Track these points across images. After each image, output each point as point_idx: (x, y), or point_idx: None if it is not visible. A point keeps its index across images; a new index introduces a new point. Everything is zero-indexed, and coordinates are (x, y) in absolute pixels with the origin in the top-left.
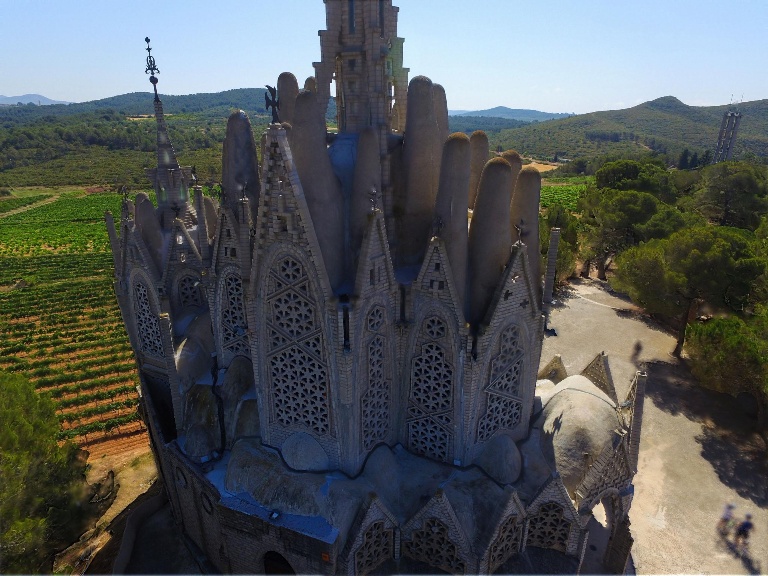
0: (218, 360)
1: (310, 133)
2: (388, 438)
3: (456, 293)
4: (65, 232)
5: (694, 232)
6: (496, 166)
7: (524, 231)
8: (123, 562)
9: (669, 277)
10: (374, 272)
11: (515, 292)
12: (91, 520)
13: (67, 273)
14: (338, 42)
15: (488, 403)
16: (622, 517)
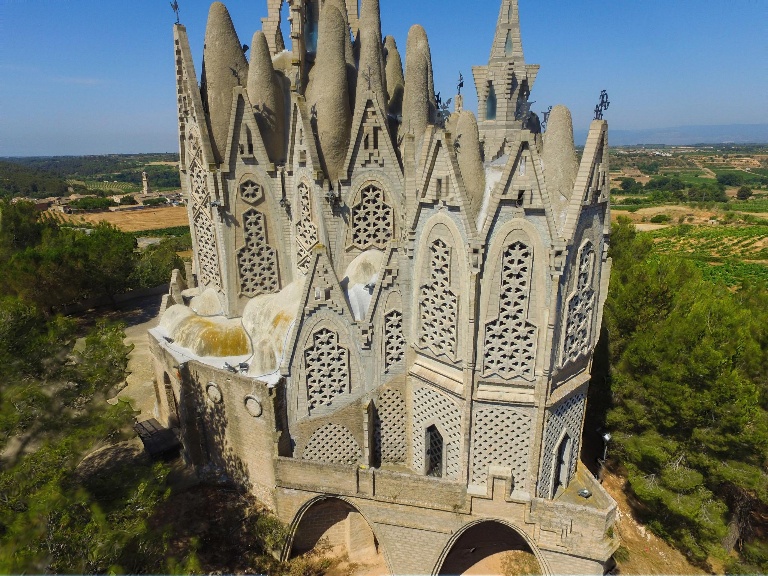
0: None
1: None
2: None
3: None
4: None
5: None
6: None
7: None
8: None
9: None
10: None
11: None
12: None
13: None
14: None
15: None
16: None
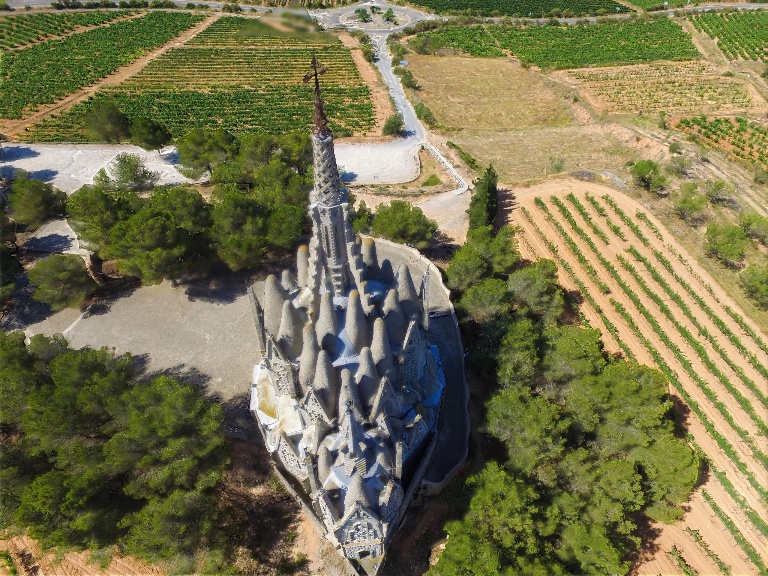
0: None
1: None
2: None
3: None
4: None
5: (151, 225)
6: None
7: None
8: None
9: (180, 253)
10: None
11: None
12: None
13: None
14: None
15: None
16: None
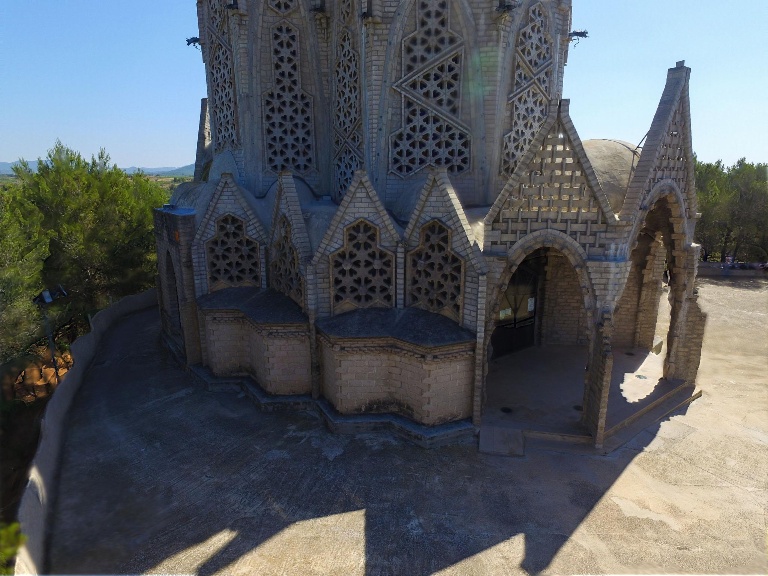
0: None
1: None
2: (313, 180)
3: None
4: None
5: None
6: None
7: None
8: (137, 304)
9: None
10: None
11: None
12: (146, 283)
13: None
14: None
15: (403, 111)
16: (597, 313)
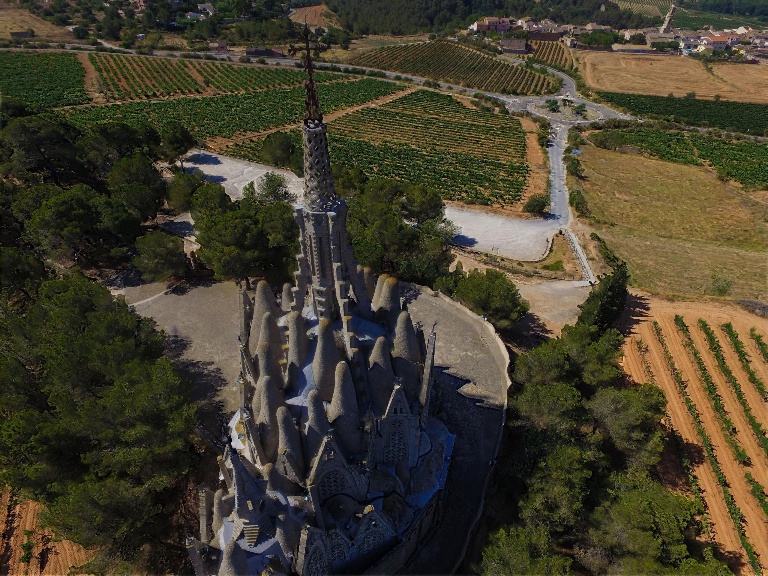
0: (364, 496)
1: None
2: None
3: None
4: None
5: (235, 224)
6: None
7: None
8: None
9: (251, 256)
10: None
11: None
12: None
13: None
14: None
15: None
16: None
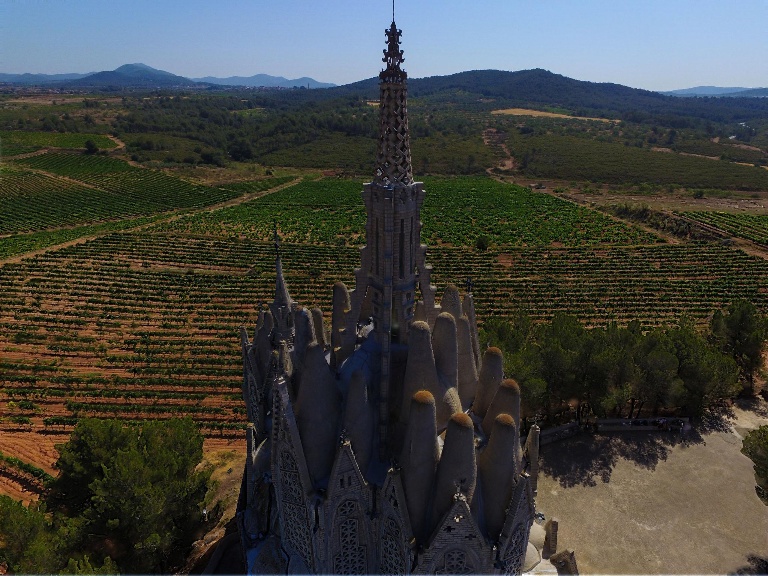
0: None
1: (311, 375)
2: None
3: (406, 514)
4: (296, 218)
5: None
6: (454, 424)
7: (493, 467)
8: (207, 575)
9: None
10: (344, 481)
11: (459, 528)
12: (201, 534)
13: (284, 264)
14: (369, 277)
15: None
16: None
